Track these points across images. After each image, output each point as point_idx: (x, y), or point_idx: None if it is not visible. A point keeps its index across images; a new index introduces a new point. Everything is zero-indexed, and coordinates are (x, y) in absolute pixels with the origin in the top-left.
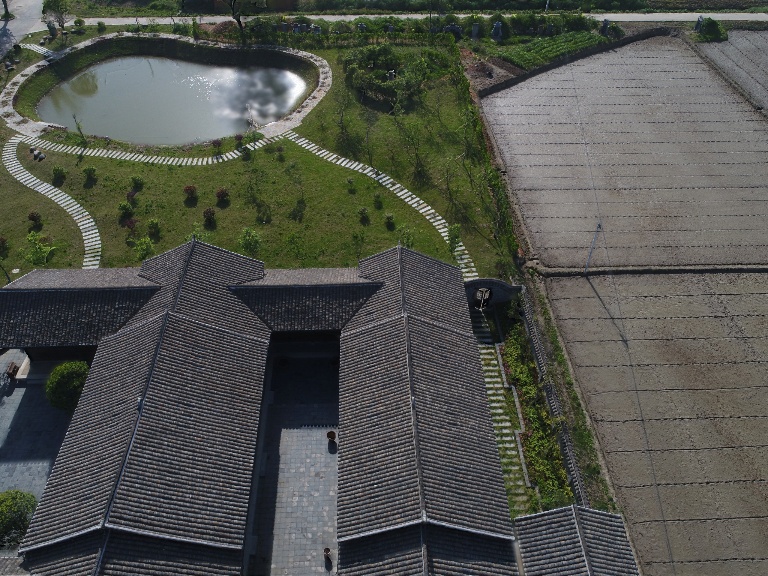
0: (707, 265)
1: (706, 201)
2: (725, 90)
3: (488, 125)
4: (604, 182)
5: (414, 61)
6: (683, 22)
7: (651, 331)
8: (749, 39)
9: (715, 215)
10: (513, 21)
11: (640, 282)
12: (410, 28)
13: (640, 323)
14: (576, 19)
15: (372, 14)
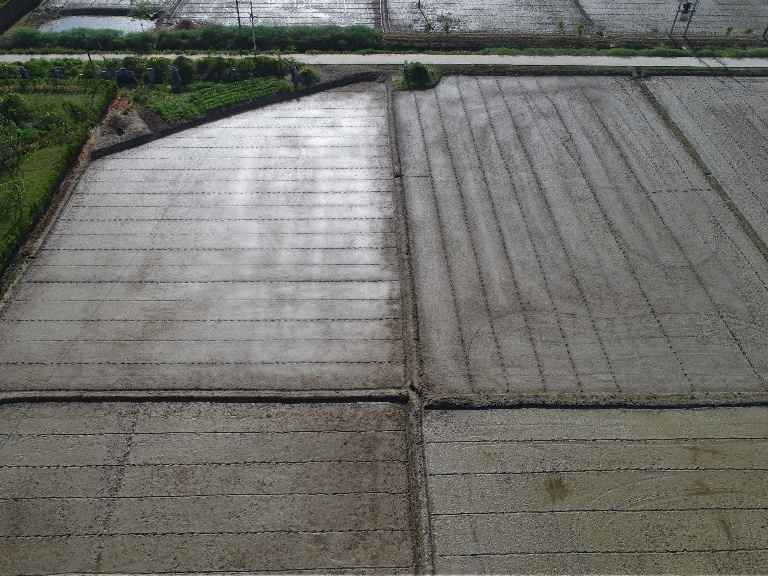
0: (154, 391)
1: (232, 300)
2: (380, 151)
3: (68, 195)
4: (135, 272)
5: (2, 120)
6: (398, 65)
7: (7, 486)
8: (460, 86)
9: (226, 320)
10: (198, 65)
11: (56, 414)
12: (81, 72)
13: (4, 474)
14: (269, 63)
15: (62, 54)
